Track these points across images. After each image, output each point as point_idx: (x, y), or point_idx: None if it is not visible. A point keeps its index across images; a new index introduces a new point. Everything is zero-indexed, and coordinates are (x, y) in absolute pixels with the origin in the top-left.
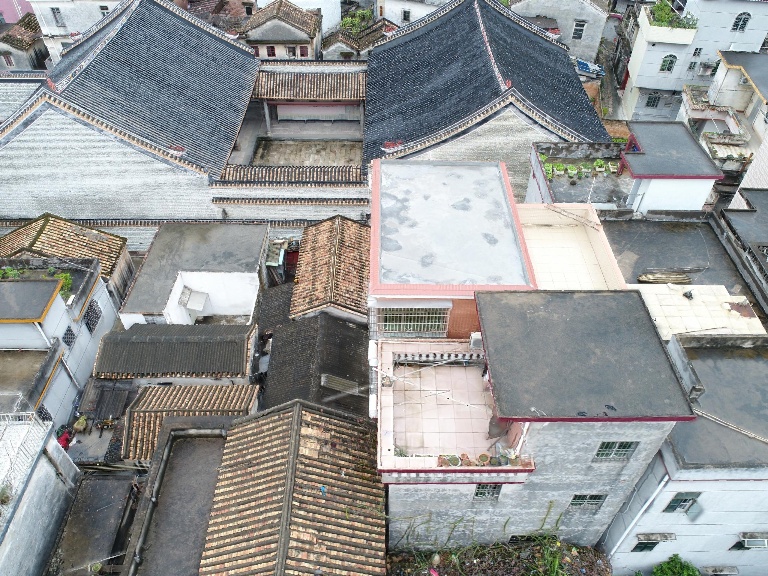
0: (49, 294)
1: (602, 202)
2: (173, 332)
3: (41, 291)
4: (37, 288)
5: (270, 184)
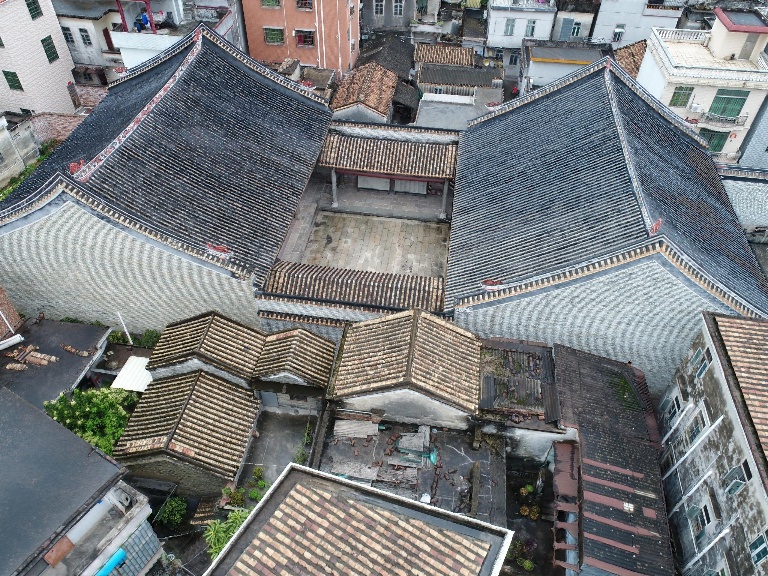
0: (534, 54)
1: (202, 8)
2: (465, 75)
3: (539, 55)
4: (543, 56)
5: (414, 128)
